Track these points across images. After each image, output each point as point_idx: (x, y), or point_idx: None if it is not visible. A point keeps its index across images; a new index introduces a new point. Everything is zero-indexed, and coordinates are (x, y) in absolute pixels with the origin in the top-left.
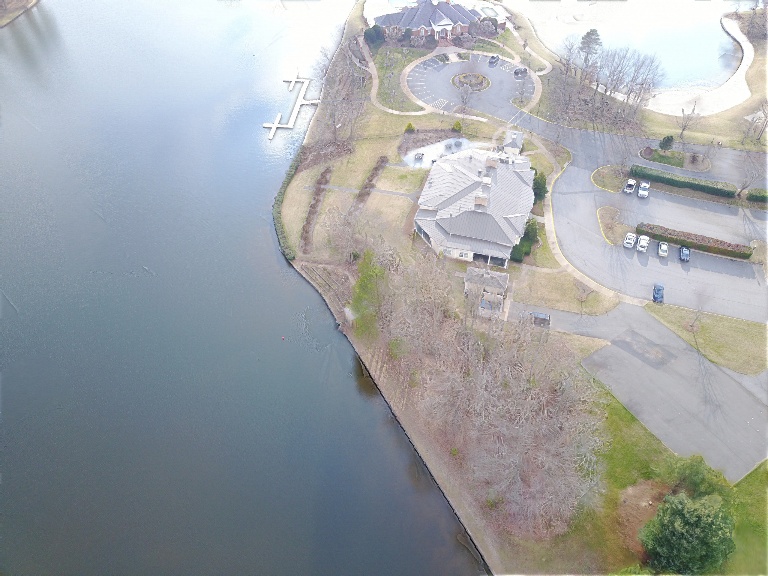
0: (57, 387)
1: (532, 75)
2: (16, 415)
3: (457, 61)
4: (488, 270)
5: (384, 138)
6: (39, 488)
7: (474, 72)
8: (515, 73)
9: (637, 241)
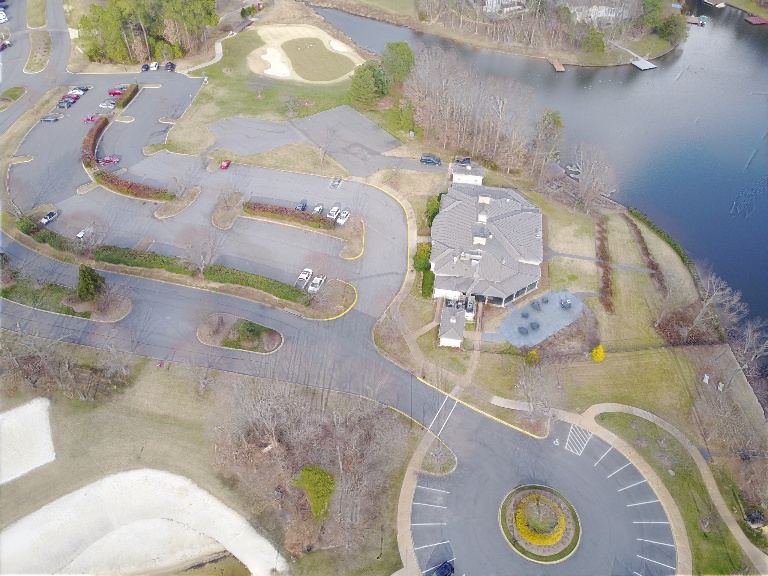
0: (718, 159)
1: (415, 567)
2: (716, 132)
3: None
4: (469, 165)
5: (626, 349)
6: (669, 116)
7: (541, 568)
8: None
9: (337, 216)
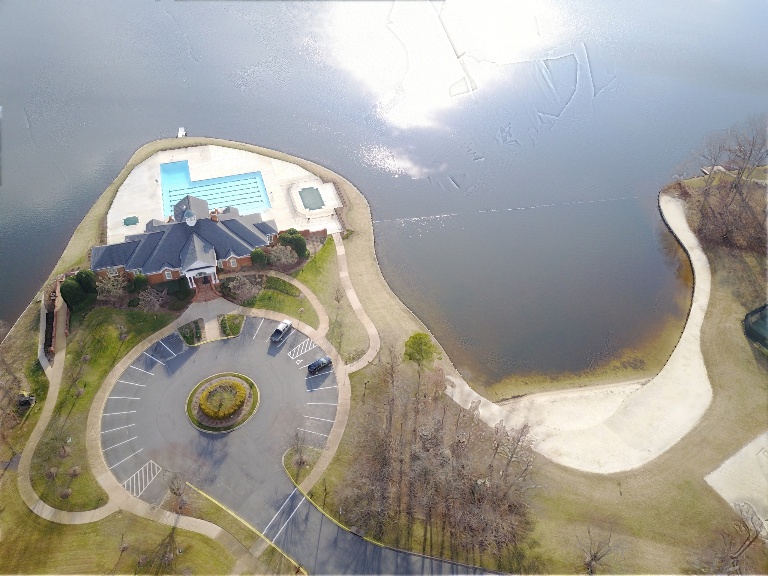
0: None
1: (339, 373)
2: None
3: (216, 339)
4: None
5: None
6: None
7: (237, 370)
8: (309, 371)
9: None
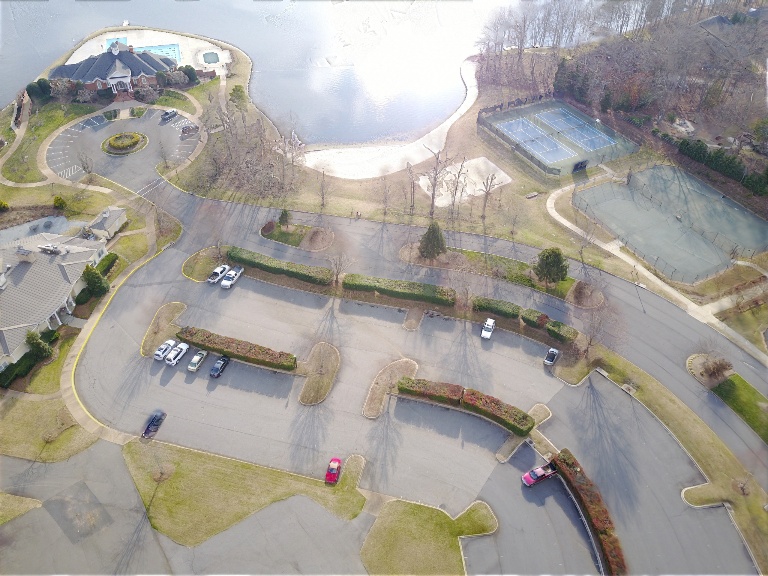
0: None
1: (201, 133)
2: None
3: (126, 118)
4: None
5: None
6: None
7: (137, 131)
8: (182, 131)
9: None
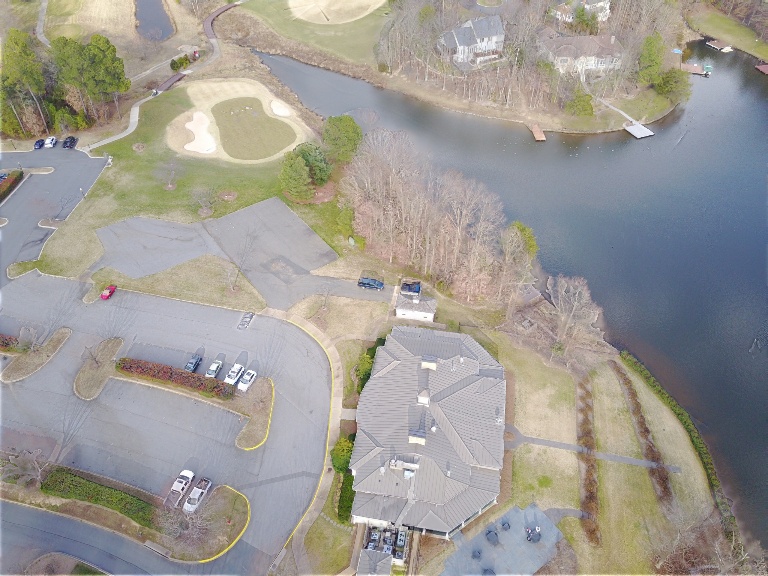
0: (731, 263)
1: None
2: (727, 227)
3: None
4: (416, 298)
5: None
6: (670, 203)
7: None
8: None
9: (240, 378)
